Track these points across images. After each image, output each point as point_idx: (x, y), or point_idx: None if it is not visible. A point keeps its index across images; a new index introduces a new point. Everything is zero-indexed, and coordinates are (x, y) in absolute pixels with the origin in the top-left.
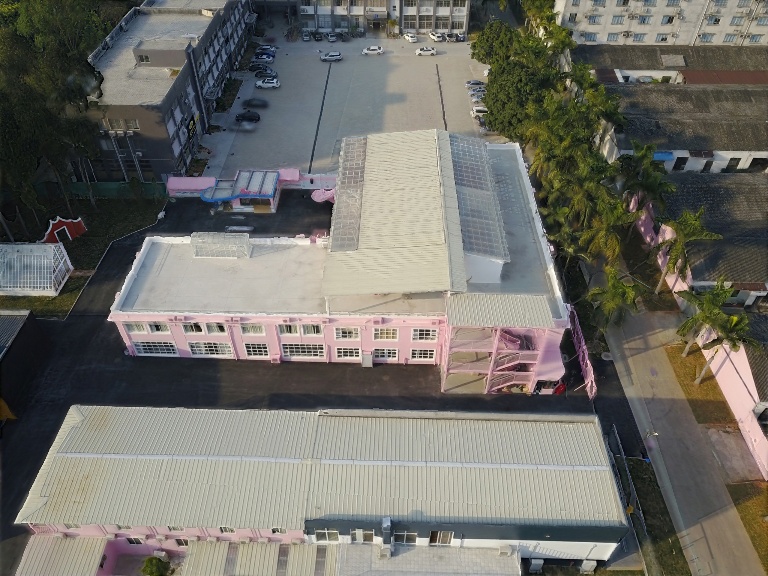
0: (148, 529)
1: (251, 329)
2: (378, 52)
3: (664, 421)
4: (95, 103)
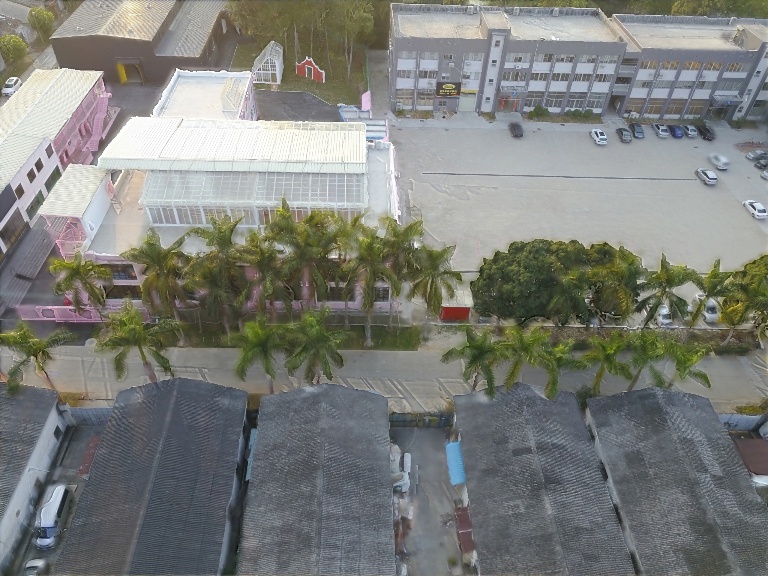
0: None
1: None
2: (754, 213)
3: None
4: (369, 7)
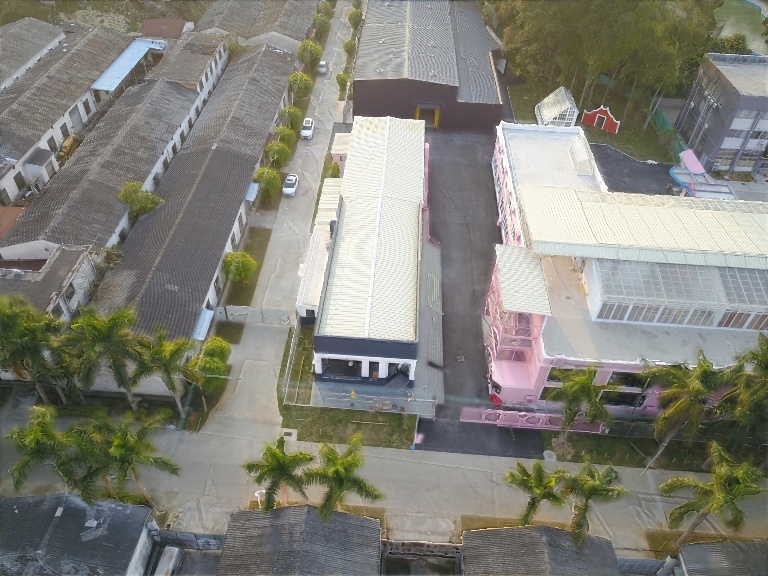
0: None
1: None
2: None
3: (462, 480)
4: (704, 60)
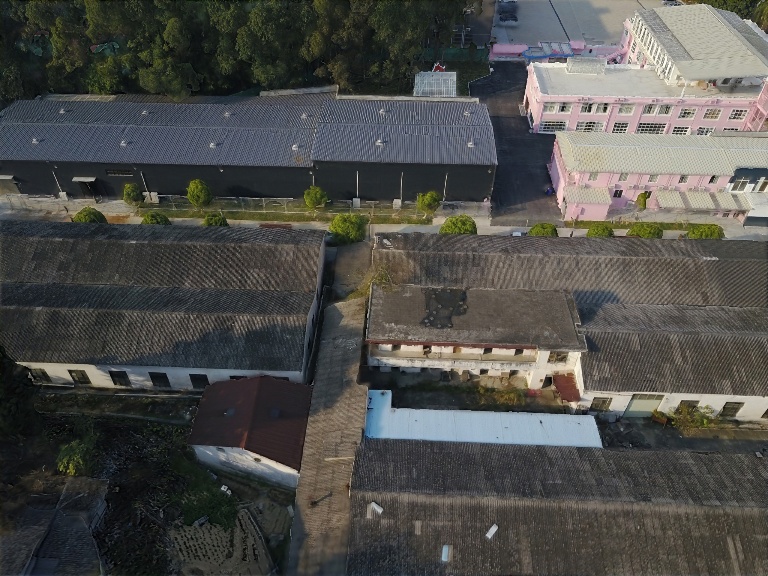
0: (637, 180)
1: (624, 110)
2: None
3: None
4: None
